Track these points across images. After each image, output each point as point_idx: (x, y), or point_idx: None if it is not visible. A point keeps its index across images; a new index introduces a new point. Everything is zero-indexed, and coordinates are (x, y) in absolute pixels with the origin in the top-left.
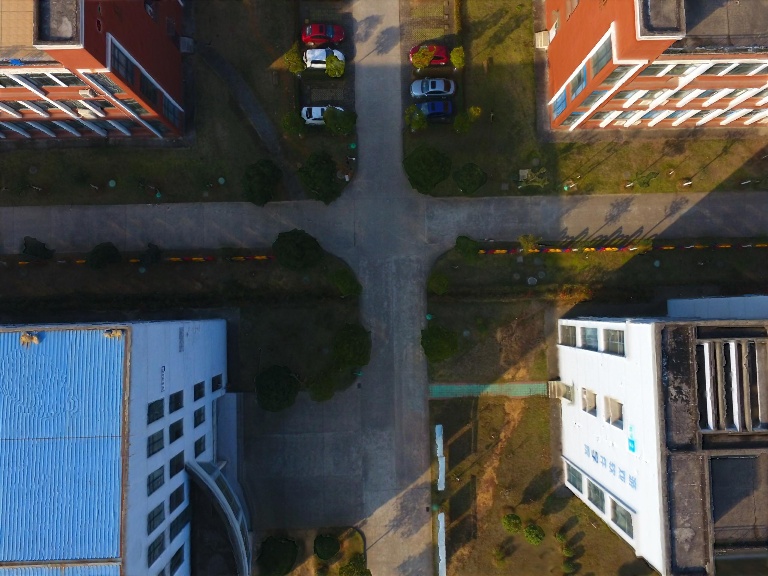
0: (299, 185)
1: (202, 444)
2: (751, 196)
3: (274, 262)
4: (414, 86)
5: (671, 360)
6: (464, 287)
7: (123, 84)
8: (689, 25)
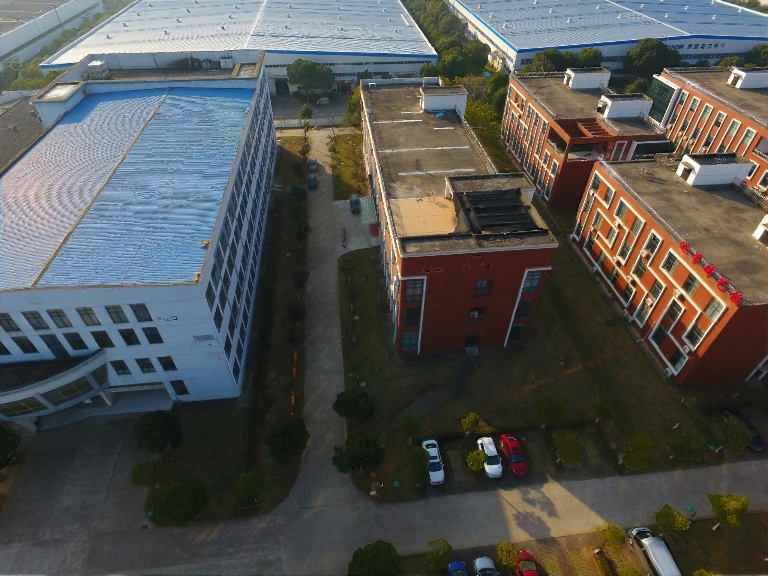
0: None
1: (124, 371)
2: None
3: None
4: (486, 559)
5: None
6: None
7: (401, 293)
8: None
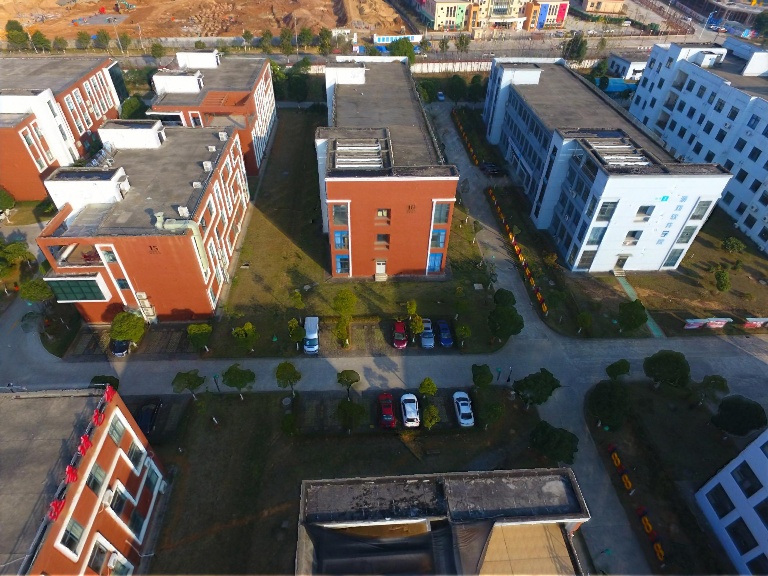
0: None
1: None
2: (465, 202)
3: None
4: (427, 344)
5: None
6: (576, 313)
7: None
8: None
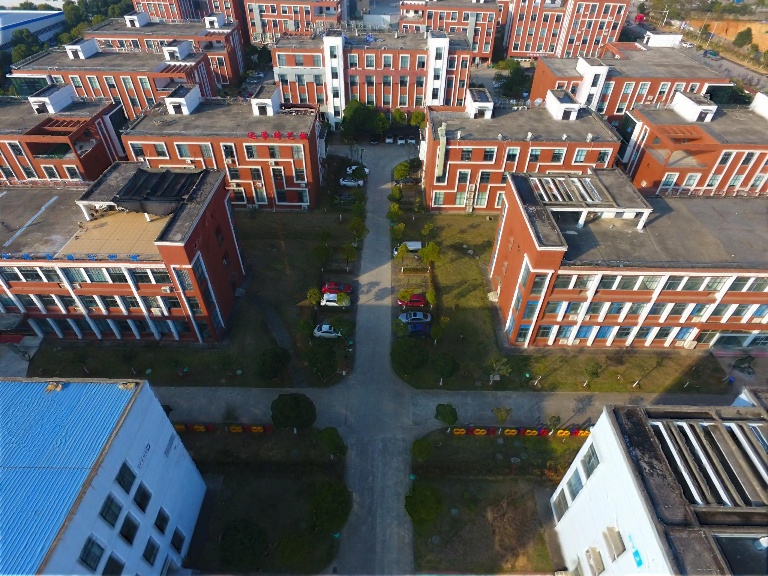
0: (303, 377)
1: None
2: (698, 397)
3: (268, 436)
4: (401, 316)
5: (632, 437)
6: (448, 460)
7: (195, 281)
8: (576, 255)
